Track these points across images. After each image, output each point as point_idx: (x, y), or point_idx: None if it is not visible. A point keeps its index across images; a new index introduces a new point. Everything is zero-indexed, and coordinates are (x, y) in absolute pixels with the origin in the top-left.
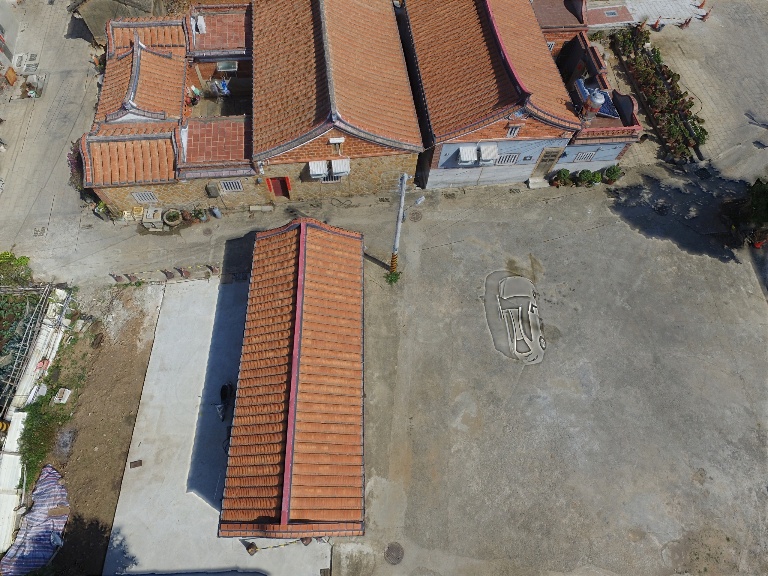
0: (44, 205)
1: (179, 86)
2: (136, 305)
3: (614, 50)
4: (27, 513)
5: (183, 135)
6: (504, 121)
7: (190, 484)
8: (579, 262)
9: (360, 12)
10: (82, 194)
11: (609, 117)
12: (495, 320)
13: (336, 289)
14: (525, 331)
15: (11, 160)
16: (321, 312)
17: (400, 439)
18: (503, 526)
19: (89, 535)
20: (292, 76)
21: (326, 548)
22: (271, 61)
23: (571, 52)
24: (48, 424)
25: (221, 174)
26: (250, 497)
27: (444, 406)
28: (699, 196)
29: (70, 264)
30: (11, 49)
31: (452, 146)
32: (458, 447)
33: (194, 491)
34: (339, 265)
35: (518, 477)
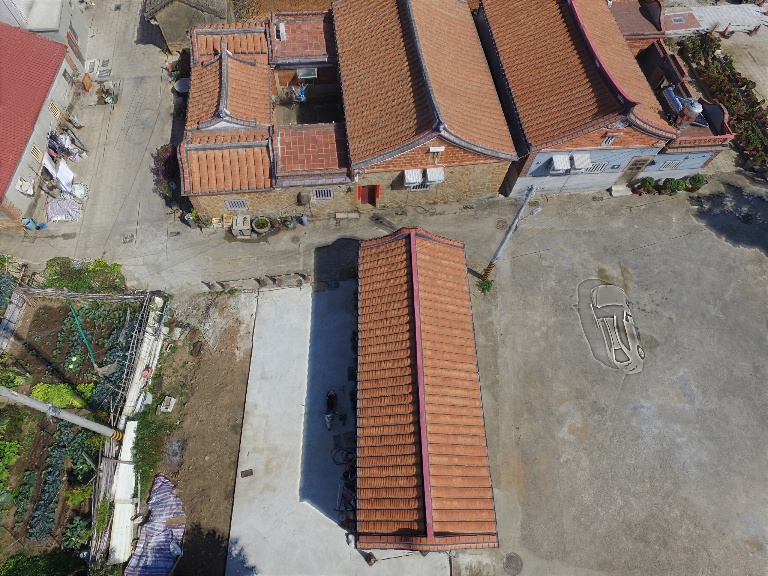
0: (130, 212)
1: (265, 93)
2: (232, 313)
3: (682, 57)
4: (144, 522)
5: (278, 143)
6: (603, 130)
7: (302, 493)
8: (669, 271)
9: (443, 20)
10: (167, 201)
11: (698, 126)
12: (591, 329)
13: (447, 299)
14: (622, 340)
15: (93, 167)
16: (436, 322)
17: (509, 449)
18: (619, 537)
19: (207, 545)
20: (385, 84)
21: (444, 558)
22: (360, 69)
23: (645, 59)
24: (157, 433)
25: (317, 182)
26: (386, 509)
27: (549, 416)
28: None
29: (162, 271)
30: (83, 55)
31: (546, 155)
32: (567, 457)
33: (307, 501)
34: (447, 275)
35: (630, 487)
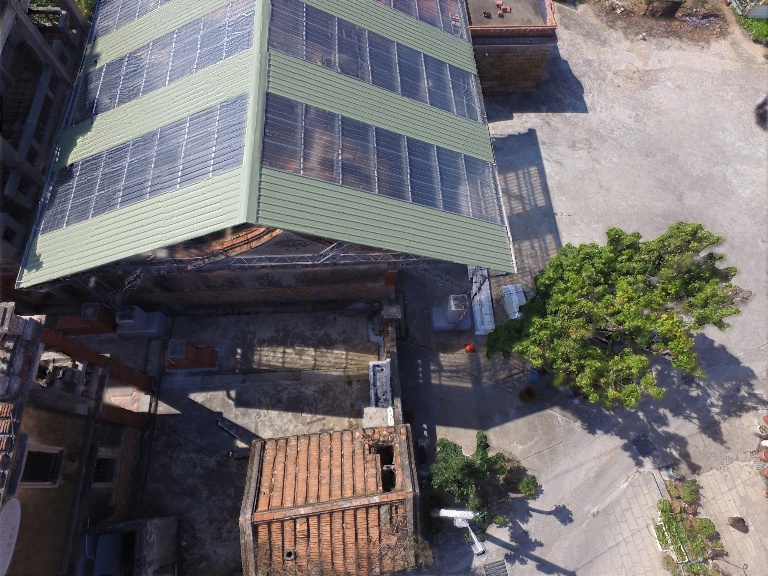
0: None
1: None
2: None
3: None
4: None
5: None
6: None
7: None
8: None
9: None
10: None
11: None
12: None
13: None
14: None
15: None
16: None
17: None
18: None
19: None
20: None
21: None
22: None
23: None
24: None
25: None
26: None
27: None
28: (647, 403)
29: None
30: None
31: None
32: None
33: None
34: None
35: None
